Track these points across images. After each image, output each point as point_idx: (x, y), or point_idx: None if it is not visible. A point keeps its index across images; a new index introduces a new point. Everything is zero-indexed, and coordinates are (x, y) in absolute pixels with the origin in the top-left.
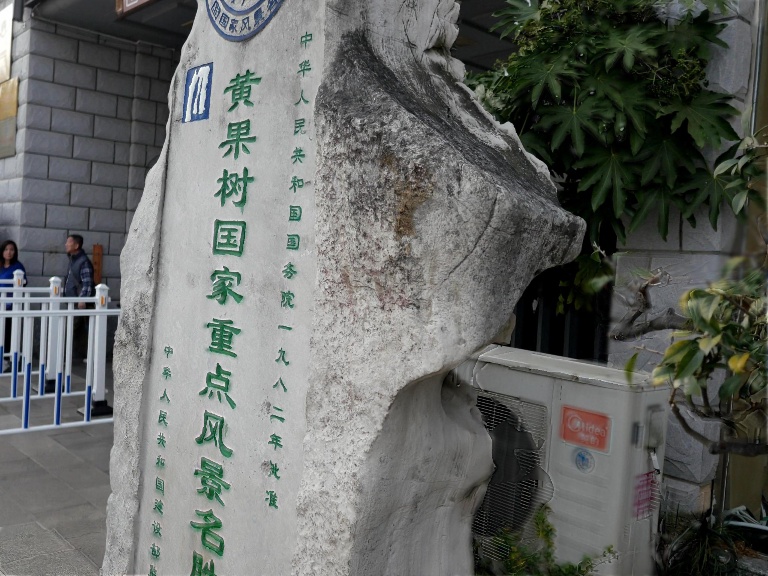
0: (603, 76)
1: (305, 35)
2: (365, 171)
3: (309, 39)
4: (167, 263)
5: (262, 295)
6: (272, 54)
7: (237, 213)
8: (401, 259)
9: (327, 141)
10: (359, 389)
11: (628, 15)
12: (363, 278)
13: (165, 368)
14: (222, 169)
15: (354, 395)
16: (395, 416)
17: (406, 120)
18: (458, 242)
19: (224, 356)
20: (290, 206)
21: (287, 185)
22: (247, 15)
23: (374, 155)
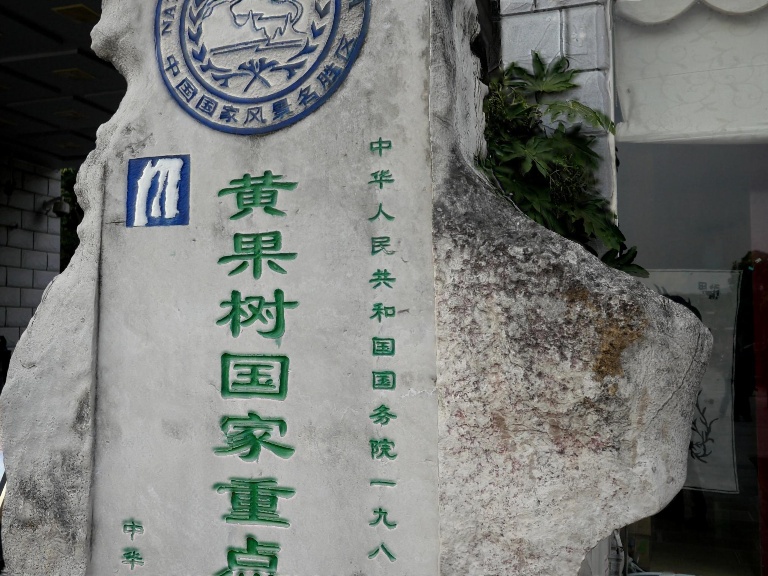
0: (519, 179)
1: (379, 141)
2: (540, 305)
3: (386, 146)
4: (115, 412)
5: (333, 446)
6: (316, 156)
7: (269, 346)
8: (601, 400)
9: (458, 268)
10: (537, 546)
11: (517, 121)
12: (531, 421)
13: (127, 554)
14: (229, 290)
15: (529, 554)
16: (581, 568)
17: (581, 251)
18: (668, 379)
19: (262, 527)
20: (374, 338)
21: (366, 313)
22: (258, 104)
23: (554, 289)
